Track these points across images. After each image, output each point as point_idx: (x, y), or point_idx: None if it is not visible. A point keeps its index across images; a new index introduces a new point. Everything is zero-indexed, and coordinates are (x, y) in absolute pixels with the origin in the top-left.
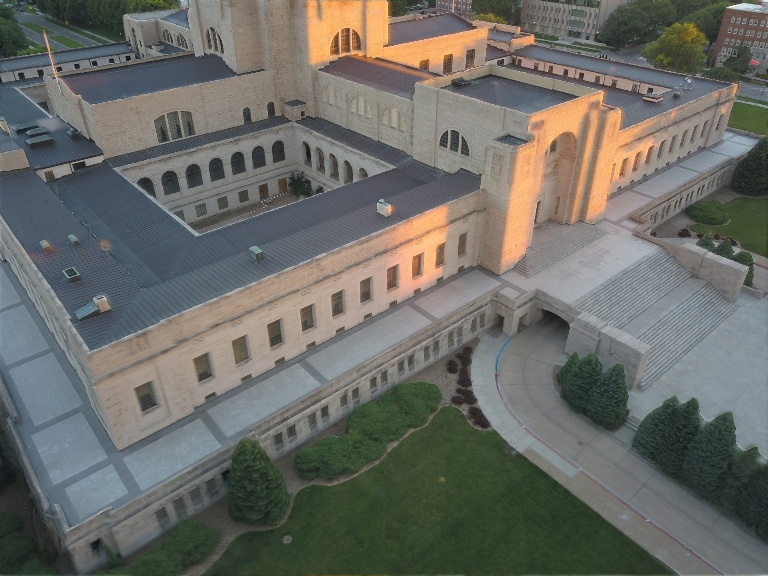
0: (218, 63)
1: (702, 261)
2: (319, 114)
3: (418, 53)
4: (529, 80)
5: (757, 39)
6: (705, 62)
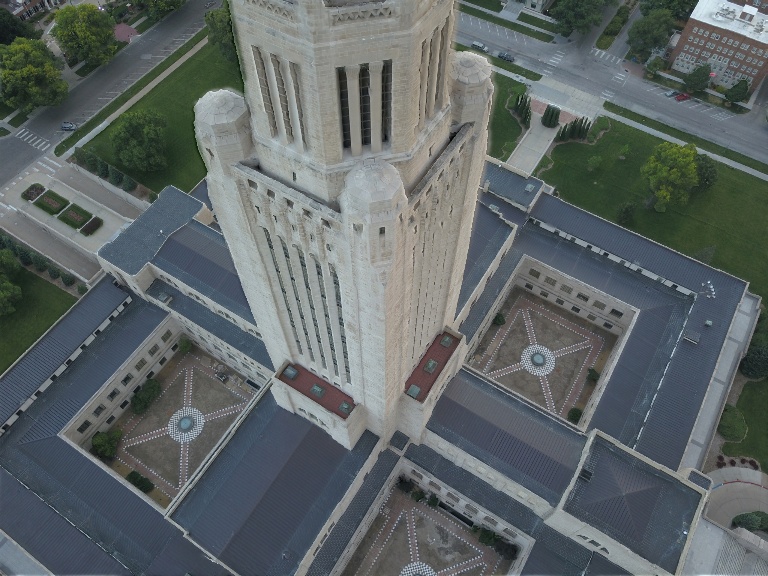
0: (324, 437)
1: (757, 548)
2: (423, 443)
3: (471, 302)
4: (637, 456)
5: (717, 53)
6: (662, 63)
